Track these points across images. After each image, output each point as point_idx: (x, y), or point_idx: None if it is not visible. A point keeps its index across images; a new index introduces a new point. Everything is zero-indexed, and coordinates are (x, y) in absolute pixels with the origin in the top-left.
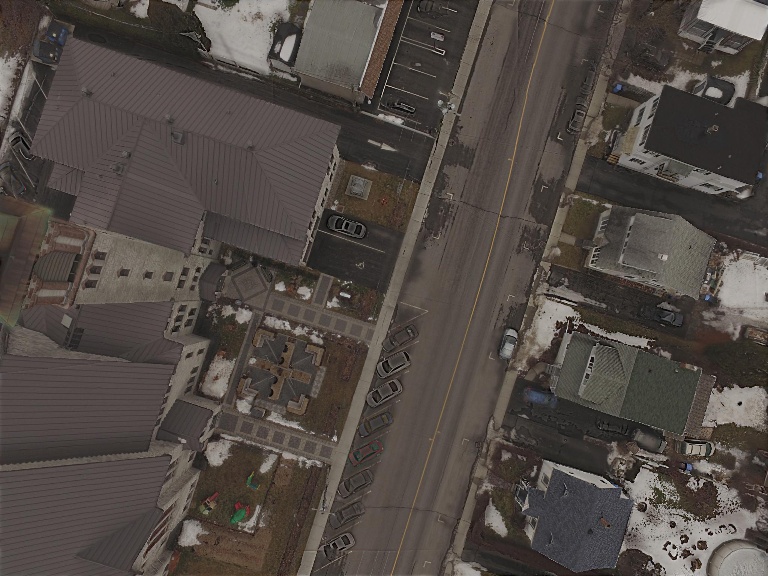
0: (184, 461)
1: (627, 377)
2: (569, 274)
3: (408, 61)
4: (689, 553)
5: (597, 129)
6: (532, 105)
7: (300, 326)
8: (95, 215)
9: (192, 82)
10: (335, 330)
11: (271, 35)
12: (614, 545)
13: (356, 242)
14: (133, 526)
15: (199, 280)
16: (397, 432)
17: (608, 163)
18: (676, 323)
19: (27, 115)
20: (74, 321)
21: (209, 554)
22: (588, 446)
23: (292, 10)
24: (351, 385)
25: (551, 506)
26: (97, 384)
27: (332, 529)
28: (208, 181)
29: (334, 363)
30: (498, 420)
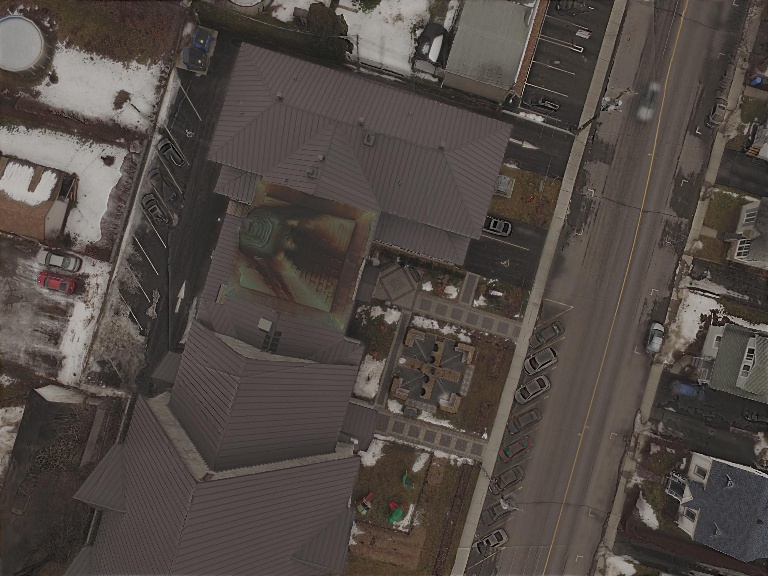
0: None
1: None
2: (711, 267)
3: (547, 59)
4: None
5: (735, 122)
6: (670, 100)
7: (448, 325)
8: None
9: (367, 85)
10: (482, 328)
11: (412, 36)
12: None
13: (501, 240)
14: (333, 527)
15: (359, 281)
16: (546, 428)
17: (747, 156)
18: None
19: (173, 122)
20: (274, 325)
21: (365, 554)
22: (735, 437)
23: (432, 11)
24: (500, 382)
25: (713, 497)
26: (306, 386)
27: (485, 526)
28: (391, 183)
29: (482, 361)
30: (645, 414)
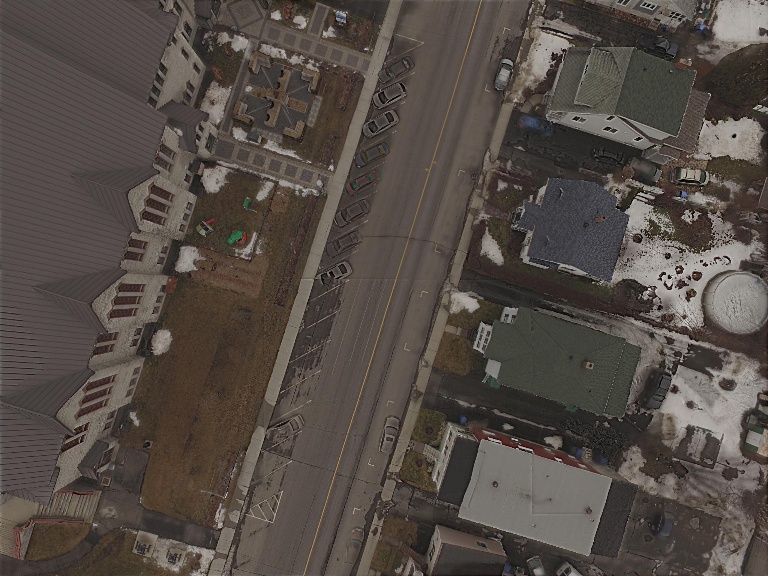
0: (180, 170)
1: (622, 76)
2: (564, 7)
3: None
4: (684, 284)
5: None
6: None
7: (296, 55)
8: None
9: None
10: (331, 60)
11: None
12: (610, 257)
13: None
14: (129, 171)
15: None
16: (393, 162)
17: None
18: (671, 51)
19: None
20: None
21: (206, 280)
22: (584, 178)
23: None
24: (347, 115)
25: (547, 212)
26: (92, 6)
27: (329, 258)
28: None
29: (330, 93)
30: (494, 152)
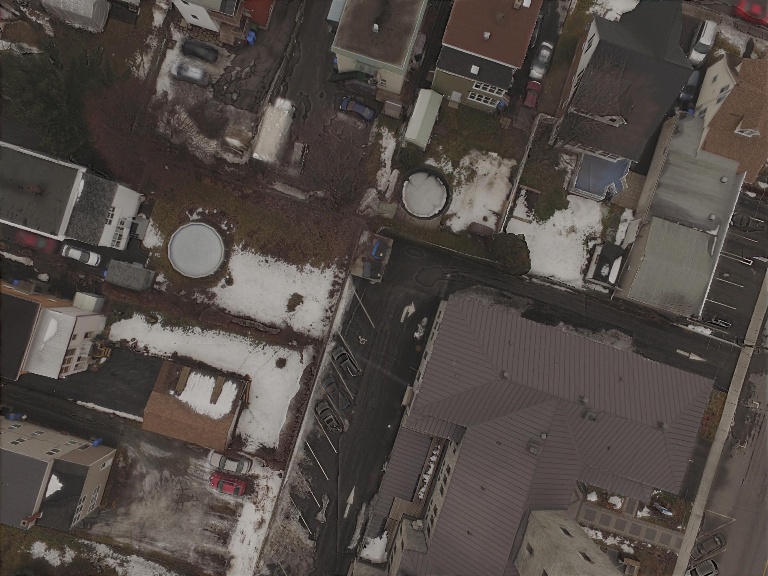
0: None
1: None
2: None
3: (717, 272)
4: None
5: None
6: None
7: (612, 536)
8: (498, 485)
9: (574, 341)
10: (645, 539)
11: (584, 248)
12: None
13: None
14: None
15: None
16: None
17: None
18: None
19: (347, 328)
20: None
21: None
22: None
23: (605, 223)
24: None
25: None
26: None
27: None
28: (600, 446)
29: (644, 572)
30: None
